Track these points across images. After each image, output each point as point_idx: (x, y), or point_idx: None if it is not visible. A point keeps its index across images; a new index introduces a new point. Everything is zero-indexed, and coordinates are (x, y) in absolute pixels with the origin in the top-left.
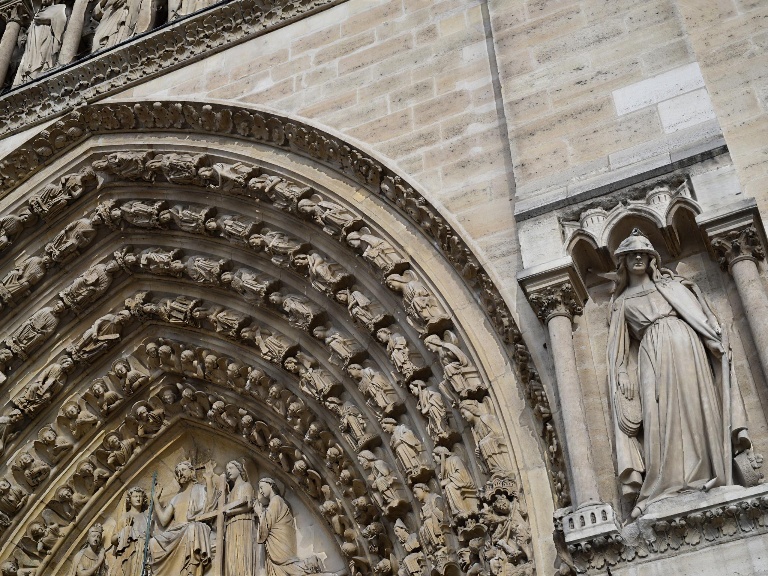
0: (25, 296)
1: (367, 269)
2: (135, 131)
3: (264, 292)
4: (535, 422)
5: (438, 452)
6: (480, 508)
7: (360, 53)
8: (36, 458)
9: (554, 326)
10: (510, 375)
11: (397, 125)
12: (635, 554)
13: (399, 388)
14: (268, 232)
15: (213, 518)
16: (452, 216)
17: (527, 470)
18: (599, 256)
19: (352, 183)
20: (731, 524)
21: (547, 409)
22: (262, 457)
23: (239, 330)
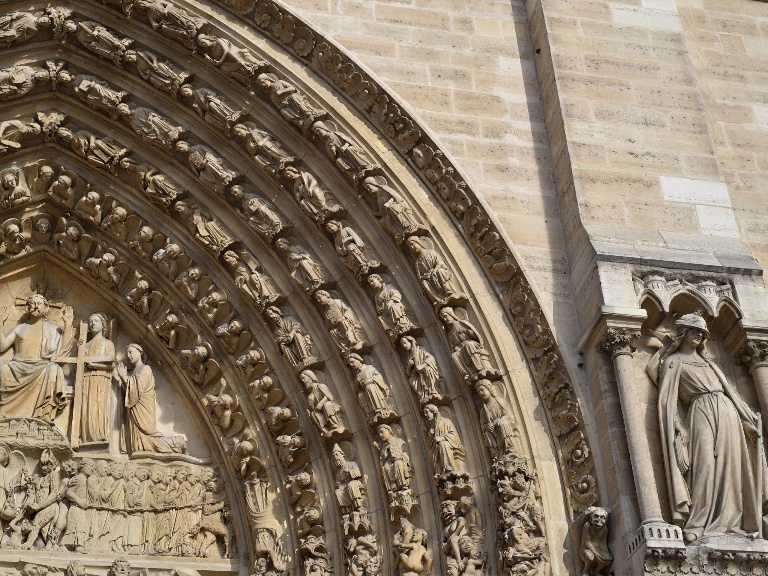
0: None
1: (367, 213)
2: None
3: (229, 181)
4: (551, 422)
5: (434, 410)
6: (497, 478)
7: (398, 8)
8: None
9: (625, 362)
10: (526, 372)
11: (438, 100)
12: (690, 569)
13: (370, 331)
14: (256, 128)
15: None
16: (494, 213)
17: (541, 459)
18: (658, 316)
19: (374, 129)
20: (760, 568)
21: (577, 418)
22: (130, 321)
23: (175, 200)
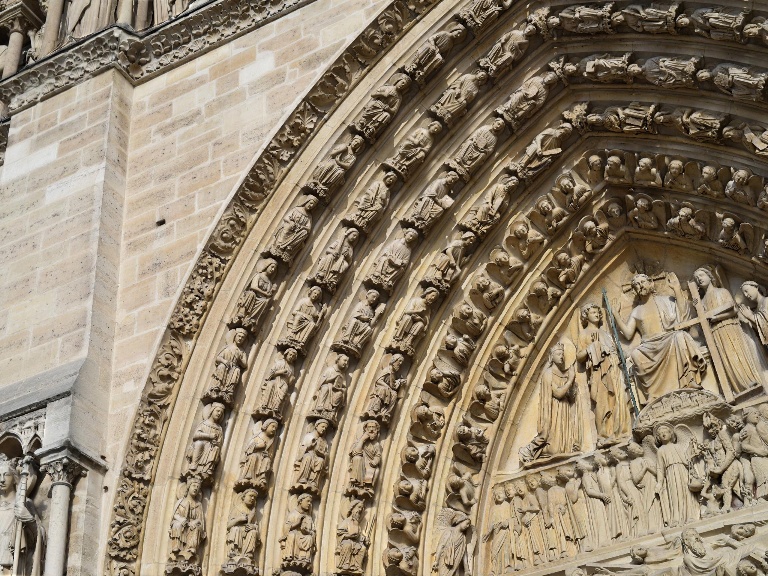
0: (460, 116)
1: None
2: None
3: (763, 84)
4: None
5: None
6: None
7: None
8: (490, 280)
9: None
10: None
11: None
12: None
13: None
14: (766, 20)
15: (688, 327)
16: None
17: None
18: None
19: None
20: None
21: None
22: (734, 262)
23: (720, 129)
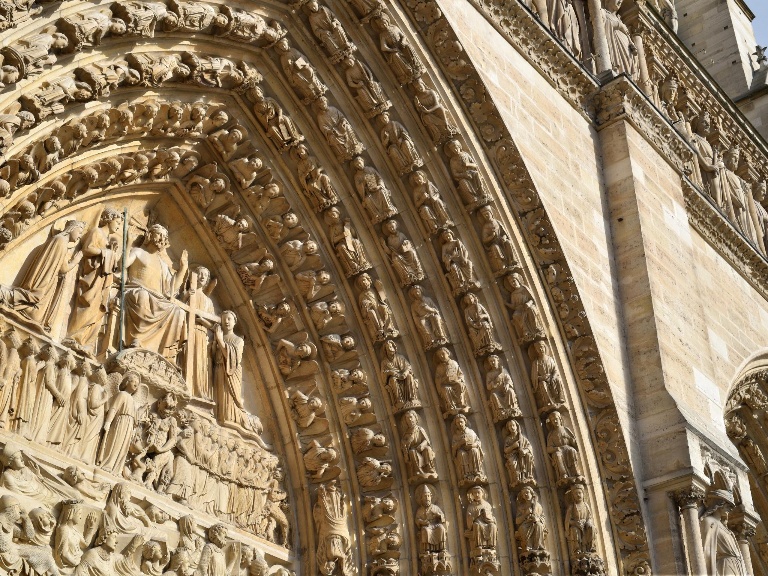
0: None
1: (497, 298)
2: None
3: (393, 214)
4: (617, 535)
5: None
6: (588, 570)
7: None
8: None
9: None
10: None
11: None
12: None
13: (474, 399)
14: None
15: None
16: None
17: None
18: None
19: None
20: None
21: None
22: (227, 286)
23: None
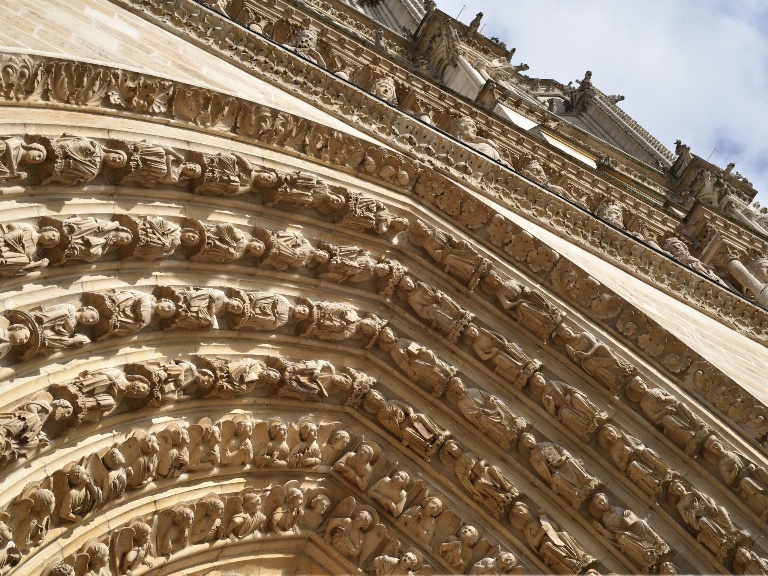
0: (275, 267)
1: None
2: (469, 233)
3: (595, 485)
4: None
5: None
6: None
7: None
8: None
9: None
10: None
11: None
12: None
13: None
14: None
15: None
16: None
17: None
18: None
19: None
20: None
21: None
22: None
23: (515, 499)
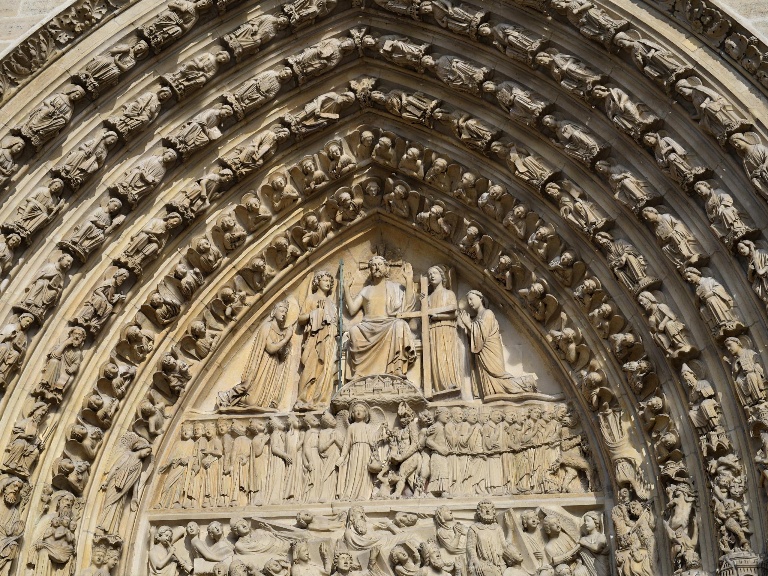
0: (251, 53)
1: (684, 118)
2: None
3: (539, 112)
4: None
5: None
6: None
7: None
8: (236, 222)
9: None
10: None
11: None
12: None
13: (705, 241)
14: (558, 53)
15: (410, 318)
16: None
17: None
18: None
19: (680, 29)
20: None
21: None
22: (467, 269)
23: (490, 142)
